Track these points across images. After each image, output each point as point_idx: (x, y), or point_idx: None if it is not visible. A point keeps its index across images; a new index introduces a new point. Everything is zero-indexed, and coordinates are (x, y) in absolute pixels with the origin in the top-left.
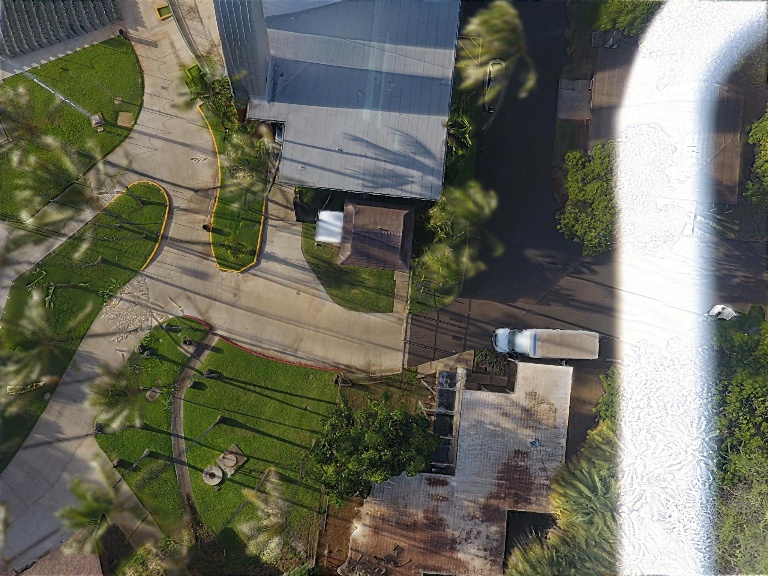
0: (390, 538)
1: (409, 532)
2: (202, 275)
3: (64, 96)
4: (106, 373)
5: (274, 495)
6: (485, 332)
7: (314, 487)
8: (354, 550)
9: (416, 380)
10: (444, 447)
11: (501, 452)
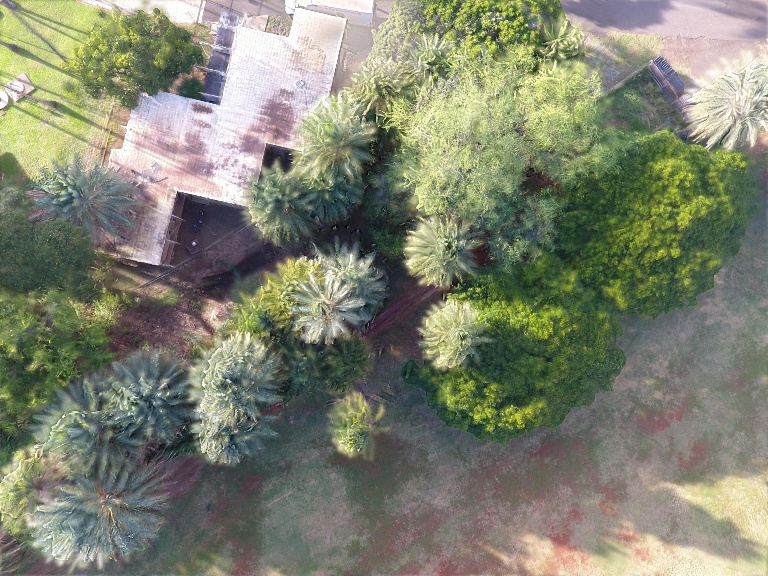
0: (150, 155)
1: (169, 152)
2: None
3: None
4: None
5: (57, 126)
6: (281, 0)
7: (96, 124)
8: (113, 162)
9: (208, 36)
10: (216, 83)
11: (267, 89)
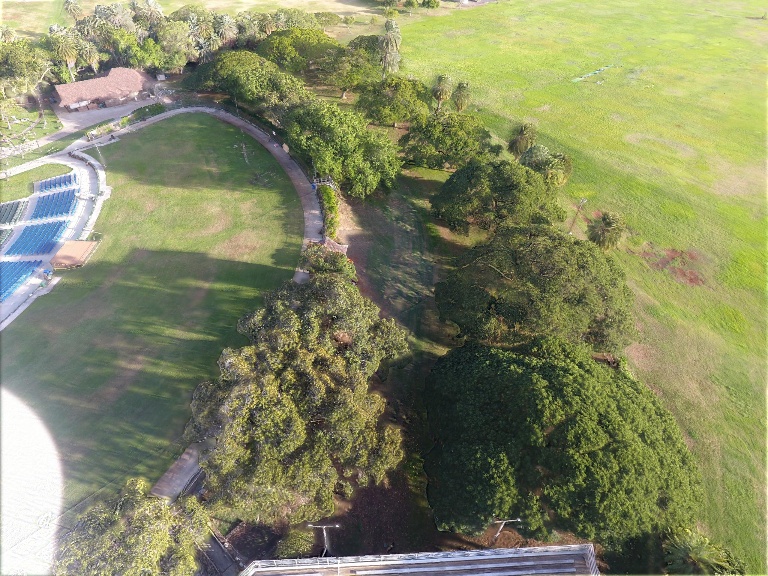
0: None
1: None
2: None
3: None
4: (47, 137)
5: None
6: None
7: None
8: None
9: None
10: None
11: None
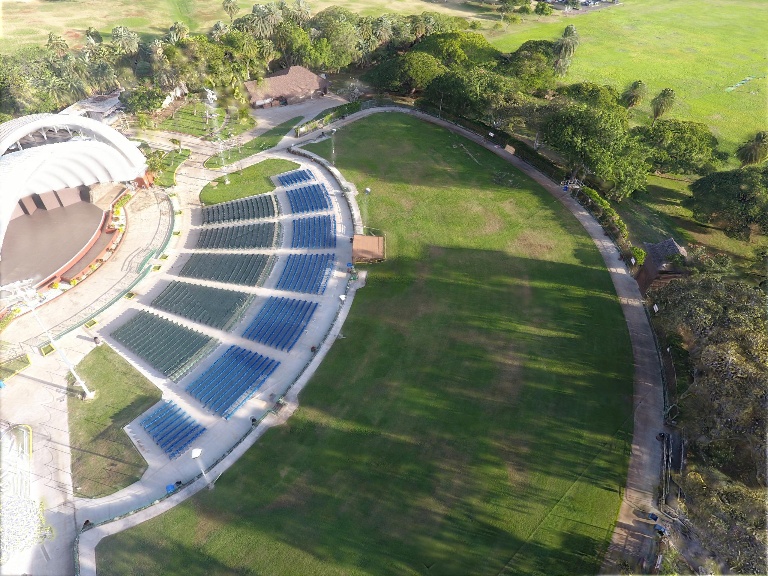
0: None
1: None
2: (199, 149)
3: (240, 188)
4: None
5: None
6: None
7: None
8: None
9: None
10: None
11: None
